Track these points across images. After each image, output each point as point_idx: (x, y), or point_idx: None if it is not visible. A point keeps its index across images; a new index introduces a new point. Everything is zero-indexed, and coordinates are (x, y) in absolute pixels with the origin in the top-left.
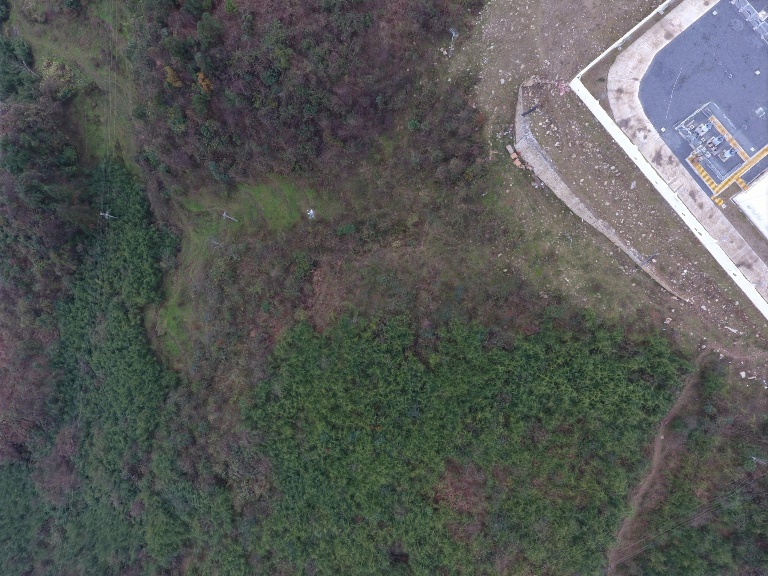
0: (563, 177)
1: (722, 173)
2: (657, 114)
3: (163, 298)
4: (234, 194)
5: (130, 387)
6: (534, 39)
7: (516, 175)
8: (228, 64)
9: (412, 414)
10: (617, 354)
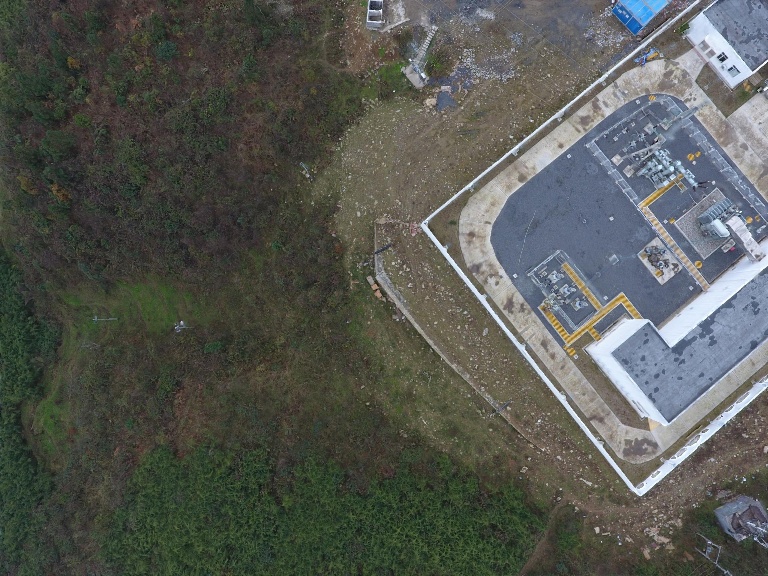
0: (417, 319)
1: (575, 322)
2: (509, 259)
3: (41, 395)
4: (113, 291)
5: (1, 491)
6: (385, 177)
7: (377, 307)
8: (85, 175)
9: (264, 560)
10: (470, 506)
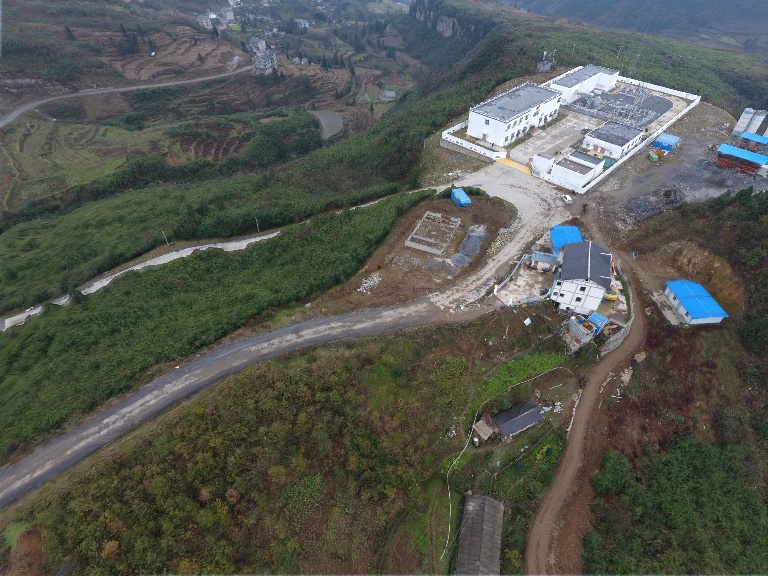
0: None
1: None
2: None
3: None
4: None
5: None
6: None
7: None
8: None
9: None
10: None
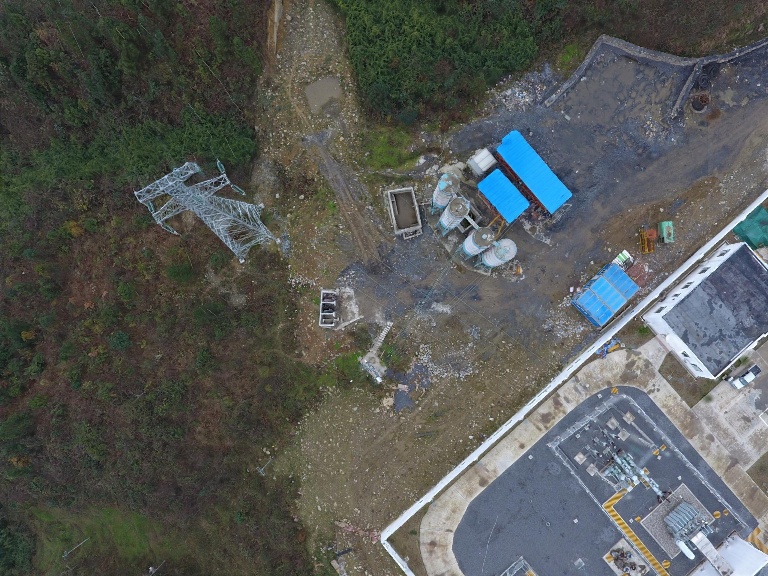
0: None
1: None
2: (472, 568)
3: None
4: (84, 511)
5: None
6: (343, 485)
7: None
8: None
9: None
10: None
